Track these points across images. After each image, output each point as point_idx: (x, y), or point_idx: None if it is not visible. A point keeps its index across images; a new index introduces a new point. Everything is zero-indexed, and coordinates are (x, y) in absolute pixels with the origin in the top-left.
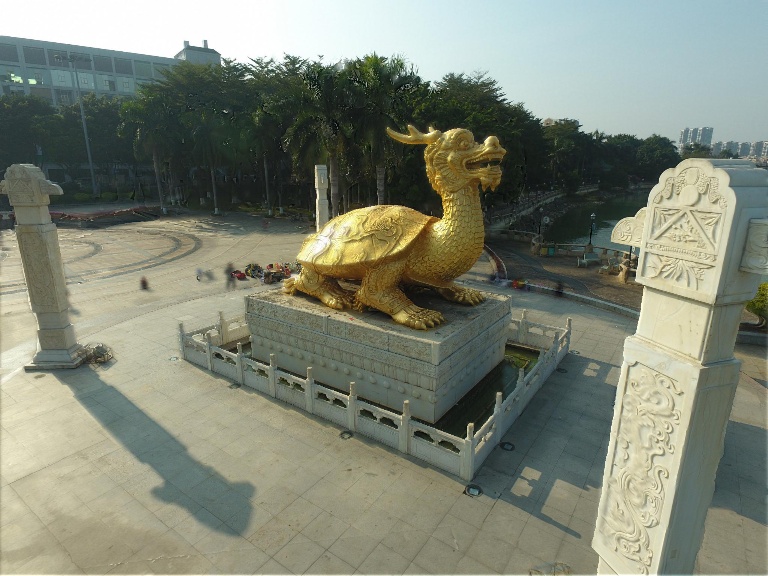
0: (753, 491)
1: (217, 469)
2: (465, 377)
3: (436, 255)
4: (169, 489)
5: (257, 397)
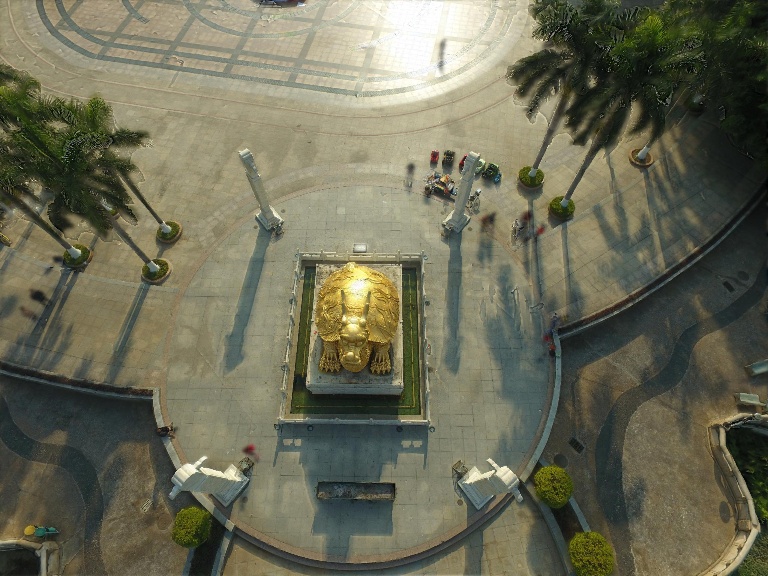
0: (333, 523)
1: (243, 344)
2: (344, 391)
3: None
4: (228, 340)
5: None
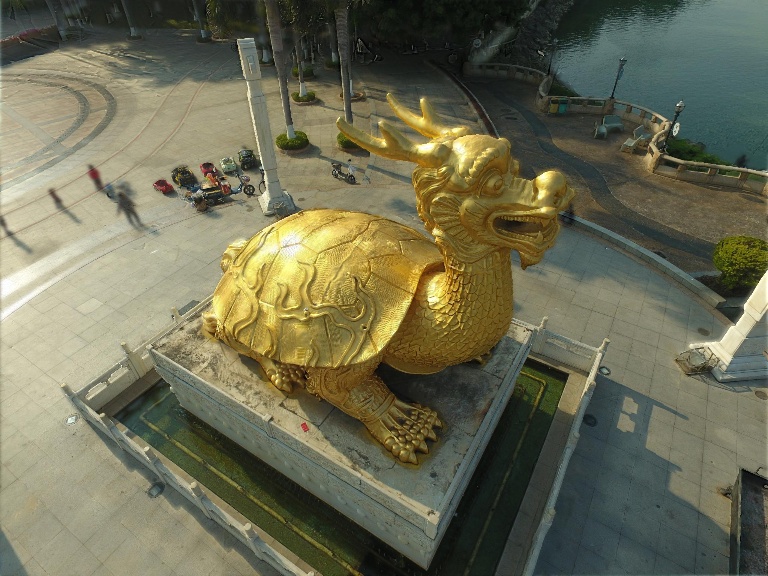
0: None
1: None
2: None
3: (432, 348)
4: None
5: (186, 518)
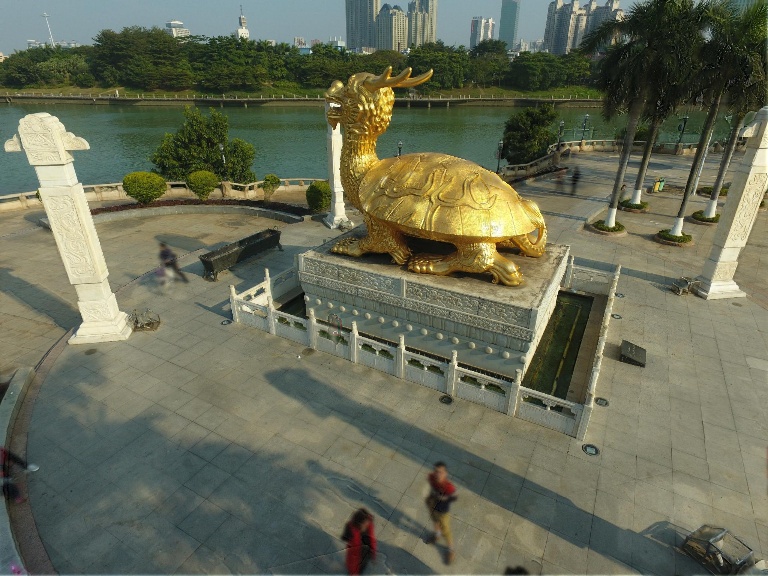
0: None
1: None
2: None
3: None
4: None
5: None
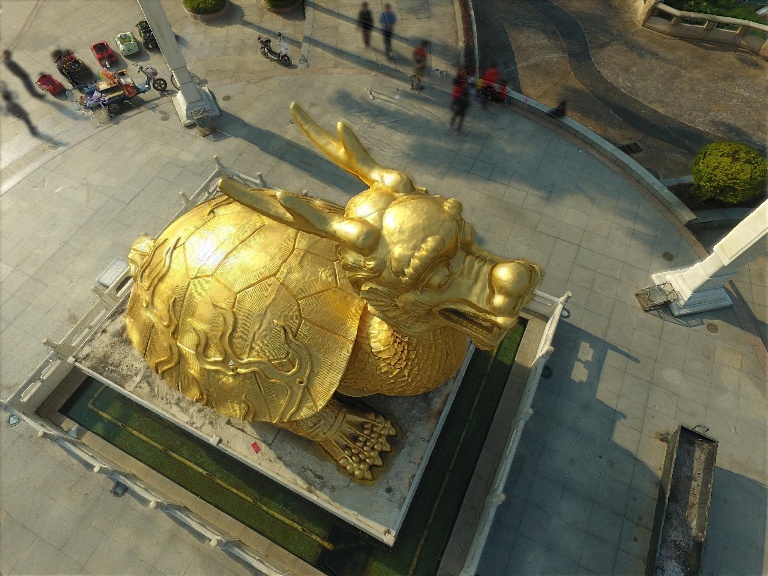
0: None
1: None
2: None
3: (379, 388)
4: None
5: (156, 515)
